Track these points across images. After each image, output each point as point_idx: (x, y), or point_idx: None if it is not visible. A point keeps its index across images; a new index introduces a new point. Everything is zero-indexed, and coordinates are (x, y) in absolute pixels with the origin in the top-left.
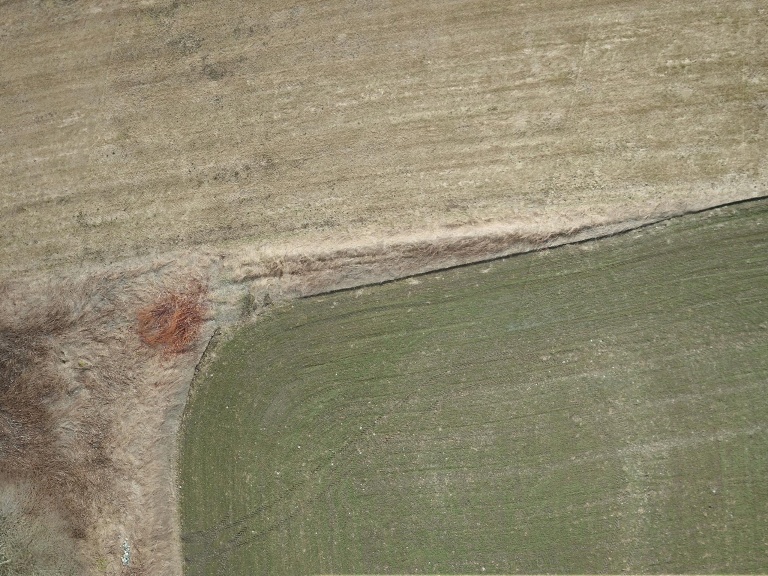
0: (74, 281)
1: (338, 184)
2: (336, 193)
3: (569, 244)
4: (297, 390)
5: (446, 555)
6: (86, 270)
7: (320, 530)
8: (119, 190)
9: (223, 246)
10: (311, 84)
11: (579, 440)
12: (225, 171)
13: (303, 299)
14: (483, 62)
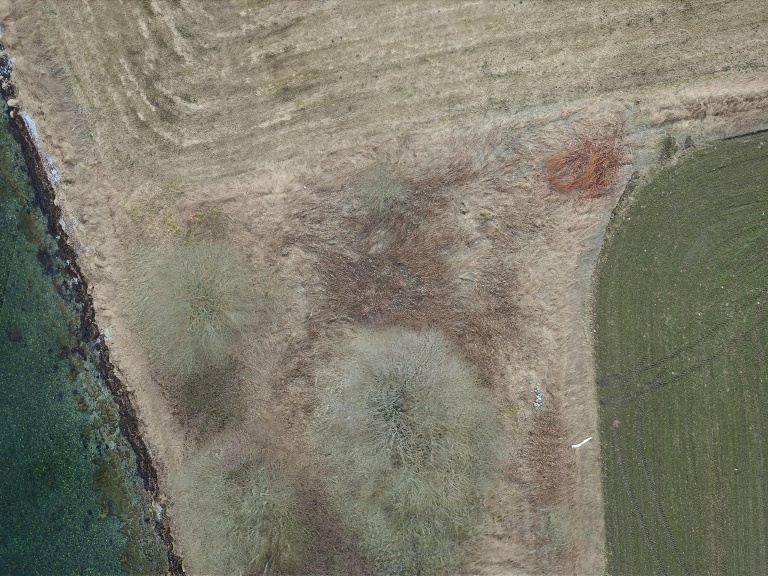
0: (478, 131)
1: (762, 26)
2: (760, 35)
3: None
4: (720, 231)
5: None
6: (491, 120)
7: (745, 369)
8: (526, 39)
9: (637, 92)
10: None
11: None
12: (639, 17)
13: (726, 140)
14: None
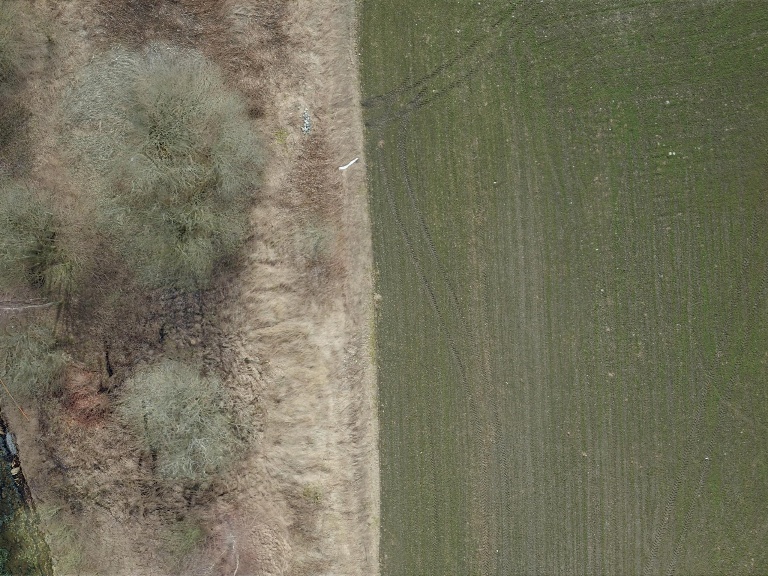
0: None
1: None
2: None
3: None
4: None
5: (630, 92)
6: None
7: (502, 83)
8: None
9: None
10: None
11: None
12: None
13: None
14: None
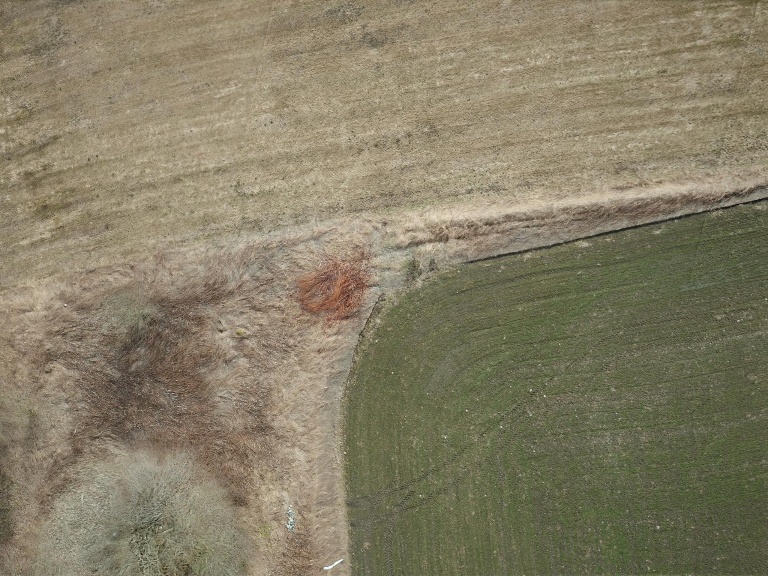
0: (232, 250)
1: (503, 149)
2: (501, 158)
3: (742, 204)
4: (464, 354)
5: (620, 514)
6: (244, 239)
7: (489, 493)
8: (277, 159)
9: (385, 213)
10: (475, 50)
11: (754, 398)
12: (386, 138)
13: (469, 264)
14: (652, 25)
